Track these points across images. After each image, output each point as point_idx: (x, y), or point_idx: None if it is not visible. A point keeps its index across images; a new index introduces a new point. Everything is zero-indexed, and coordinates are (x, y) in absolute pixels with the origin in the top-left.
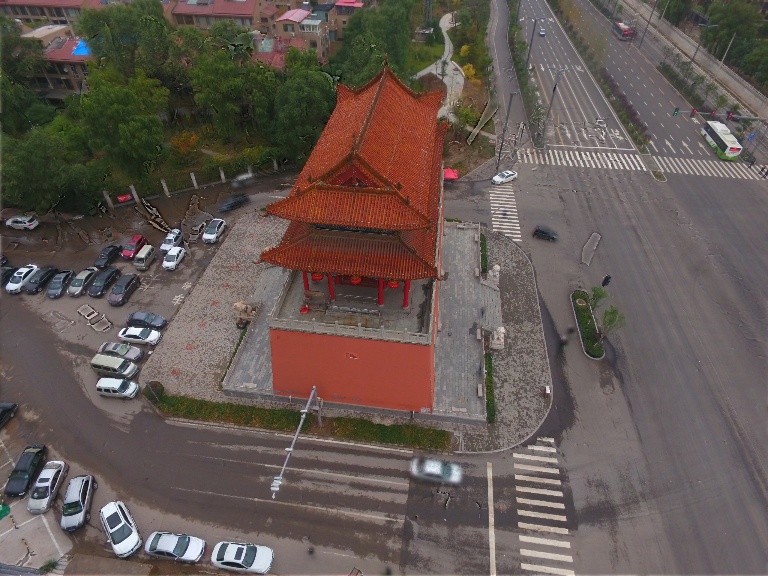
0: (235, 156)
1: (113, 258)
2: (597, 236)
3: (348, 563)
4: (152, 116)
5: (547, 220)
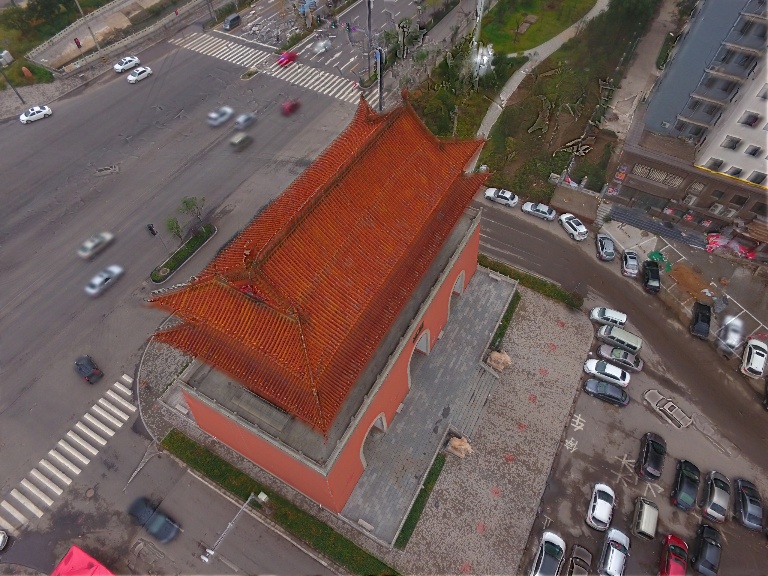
0: None
1: (699, 546)
2: (306, 5)
3: None
4: None
5: (48, 400)
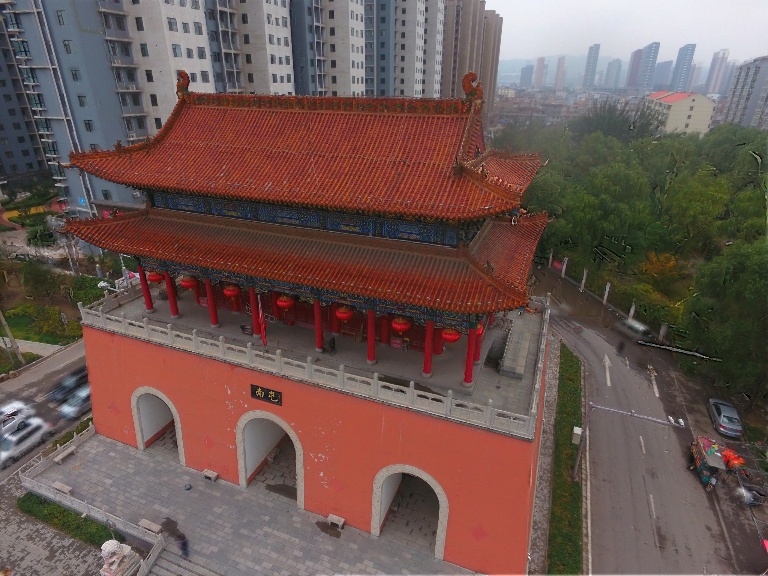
0: (661, 301)
1: None
2: None
3: (53, 366)
4: (622, 204)
5: None
